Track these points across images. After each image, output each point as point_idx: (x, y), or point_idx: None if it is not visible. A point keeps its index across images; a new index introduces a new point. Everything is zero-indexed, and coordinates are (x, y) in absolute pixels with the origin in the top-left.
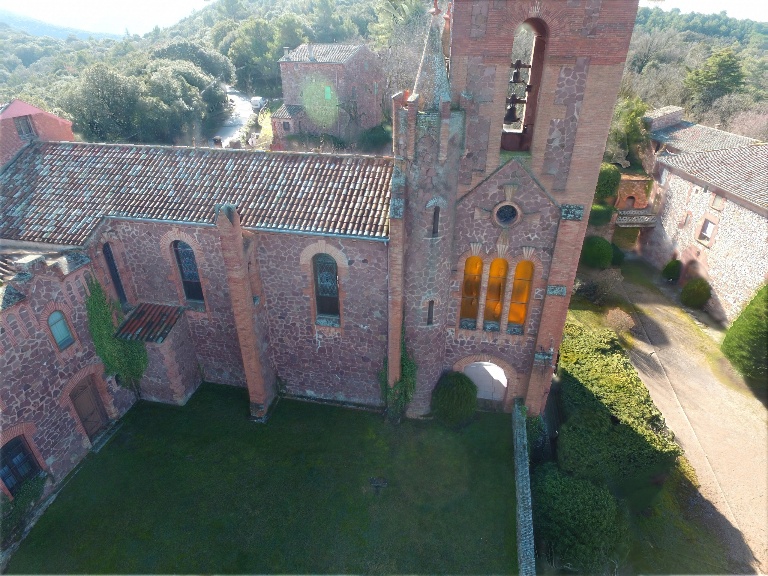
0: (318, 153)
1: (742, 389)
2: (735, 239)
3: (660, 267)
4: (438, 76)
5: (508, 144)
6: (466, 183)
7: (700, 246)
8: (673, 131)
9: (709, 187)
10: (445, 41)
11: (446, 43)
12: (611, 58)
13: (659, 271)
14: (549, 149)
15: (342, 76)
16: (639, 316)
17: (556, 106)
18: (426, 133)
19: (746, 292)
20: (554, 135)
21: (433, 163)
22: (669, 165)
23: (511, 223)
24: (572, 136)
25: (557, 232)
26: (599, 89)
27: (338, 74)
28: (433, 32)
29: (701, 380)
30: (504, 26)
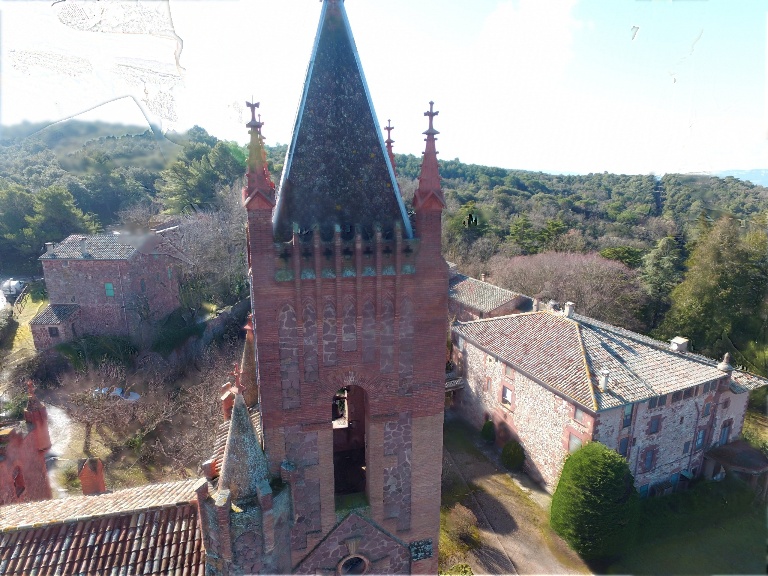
0: (92, 516)
1: (578, 565)
2: (531, 406)
3: (477, 426)
4: (251, 457)
5: (335, 441)
6: (301, 547)
7: (505, 410)
8: (454, 284)
9: (499, 358)
10: (250, 351)
11: (251, 353)
12: (431, 410)
13: (477, 430)
14: (387, 495)
15: (126, 272)
16: (476, 497)
17: (387, 457)
18: (245, 531)
19: (552, 455)
20: (389, 482)
21: (258, 557)
22: (463, 335)
23: (359, 573)
24: (408, 479)
25: (410, 572)
26: (425, 436)
27: (121, 270)
28: (238, 412)
29: (545, 567)
30: (320, 396)
